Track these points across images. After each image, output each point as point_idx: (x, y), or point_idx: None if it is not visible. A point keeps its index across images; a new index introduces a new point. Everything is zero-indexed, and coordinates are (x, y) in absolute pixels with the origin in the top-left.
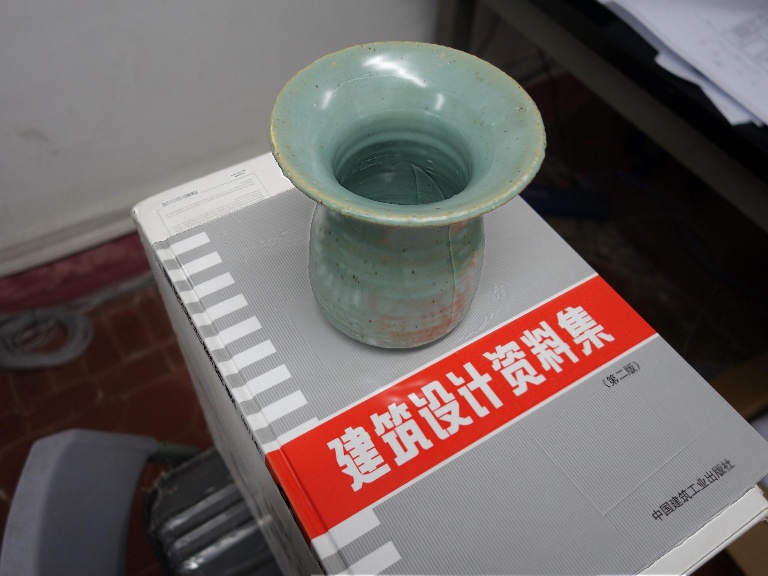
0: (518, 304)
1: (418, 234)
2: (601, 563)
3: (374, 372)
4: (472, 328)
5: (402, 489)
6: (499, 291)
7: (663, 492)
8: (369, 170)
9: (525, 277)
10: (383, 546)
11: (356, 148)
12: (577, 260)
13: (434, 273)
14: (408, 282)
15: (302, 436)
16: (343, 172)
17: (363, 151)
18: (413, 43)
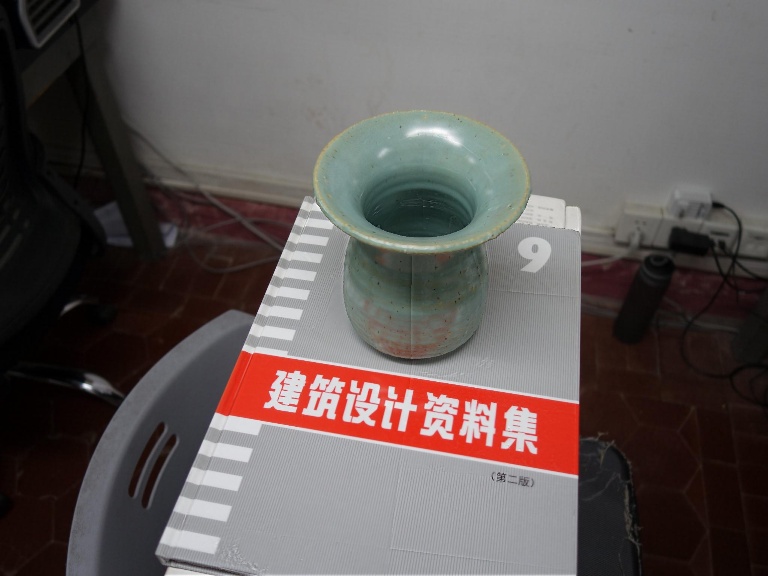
0: (490, 380)
1: (385, 255)
2: (355, 572)
3: (348, 352)
4: (439, 371)
5: (289, 428)
6: (486, 362)
7: (449, 573)
8: (432, 211)
9: (517, 366)
10: (246, 448)
11: (416, 185)
12: (573, 383)
13: (394, 294)
14: (374, 289)
15: (269, 356)
16: (401, 198)
17: (423, 191)
18: (491, 129)
